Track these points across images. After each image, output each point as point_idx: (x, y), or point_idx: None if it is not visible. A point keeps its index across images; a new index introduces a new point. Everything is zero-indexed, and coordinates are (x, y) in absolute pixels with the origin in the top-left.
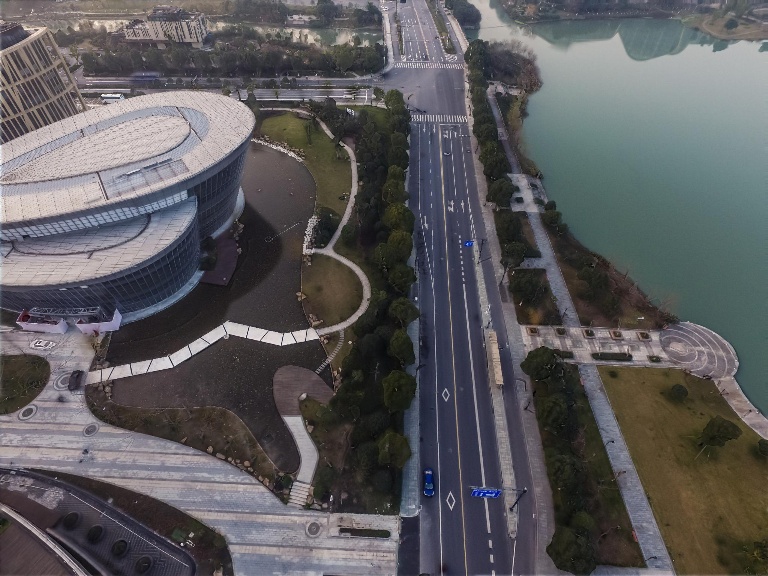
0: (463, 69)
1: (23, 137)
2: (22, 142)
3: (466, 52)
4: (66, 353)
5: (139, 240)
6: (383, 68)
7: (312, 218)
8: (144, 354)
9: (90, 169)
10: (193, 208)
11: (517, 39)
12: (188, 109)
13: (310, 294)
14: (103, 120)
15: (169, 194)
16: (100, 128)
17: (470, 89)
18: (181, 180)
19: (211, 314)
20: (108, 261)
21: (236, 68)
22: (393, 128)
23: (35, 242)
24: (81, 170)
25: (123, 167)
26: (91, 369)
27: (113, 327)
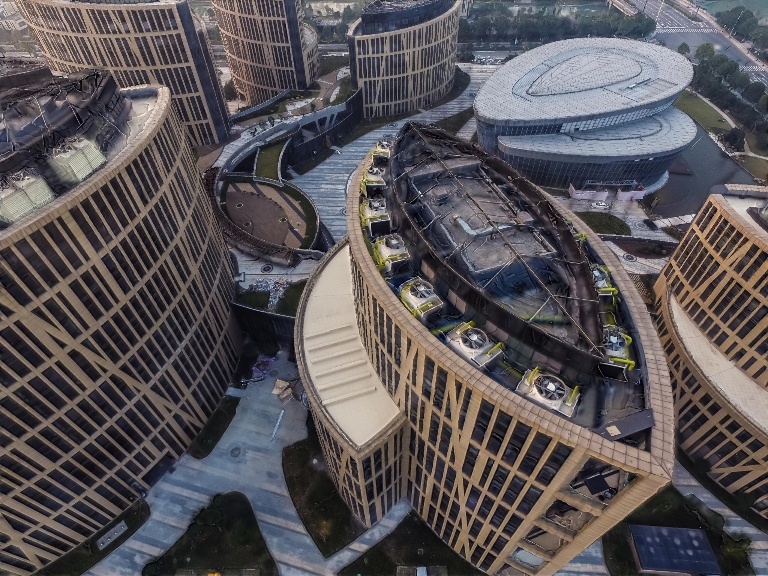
0: (721, 33)
1: (502, 69)
2: (507, 71)
3: (734, 16)
4: (621, 211)
5: (667, 131)
6: (653, 32)
7: (710, 134)
8: (678, 212)
9: (593, 85)
10: (682, 112)
11: (757, 8)
12: (612, 49)
13: (765, 179)
14: (551, 57)
15: (669, 101)
16: (557, 62)
17: (754, 45)
18: (680, 90)
19: (700, 191)
20: (662, 142)
21: (532, 33)
22: (728, 71)
23: (584, 133)
24: (587, 86)
25: (618, 84)
26: (652, 219)
27: (641, 196)
